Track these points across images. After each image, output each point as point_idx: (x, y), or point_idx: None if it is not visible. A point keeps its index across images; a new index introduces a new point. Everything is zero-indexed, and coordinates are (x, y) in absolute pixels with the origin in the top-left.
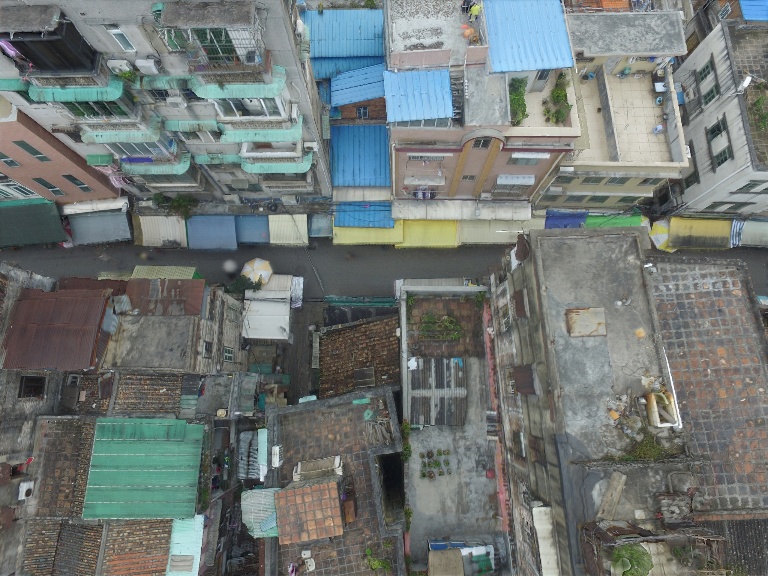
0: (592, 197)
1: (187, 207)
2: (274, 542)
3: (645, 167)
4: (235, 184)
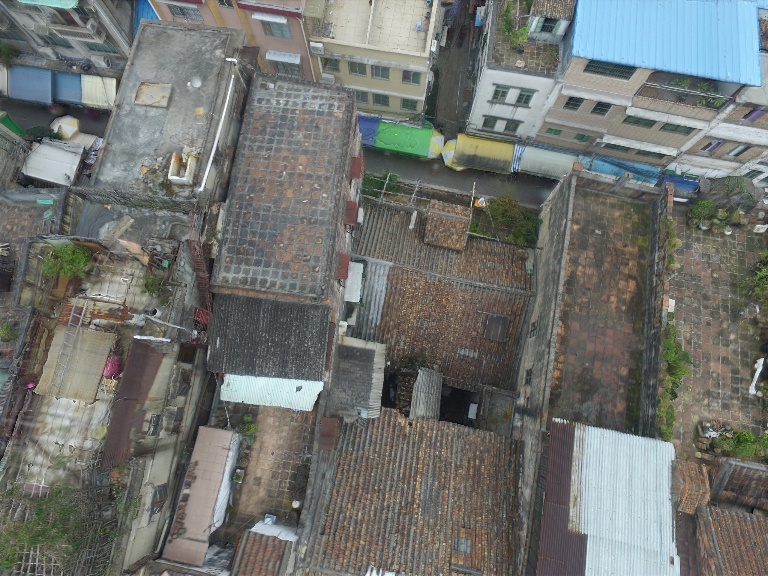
0: (375, 97)
1: (9, 56)
2: None
3: (390, 53)
4: (37, 30)
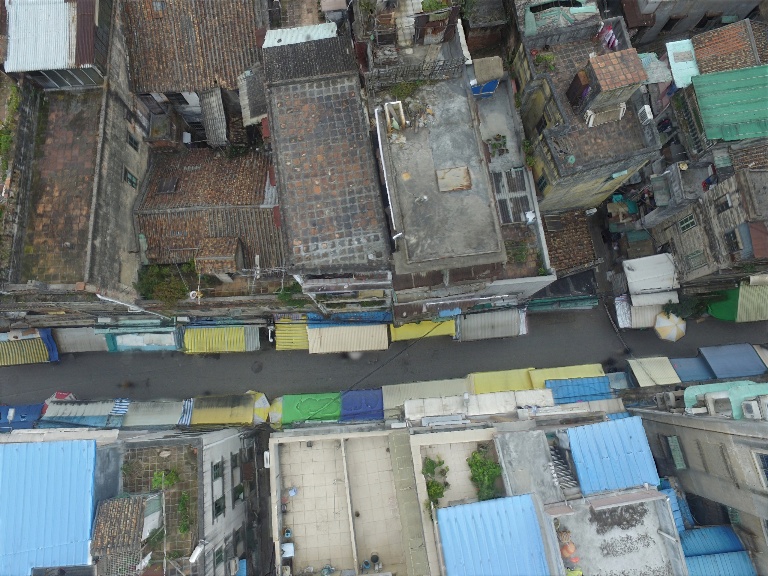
0: None
1: None
2: None
3: None
4: None
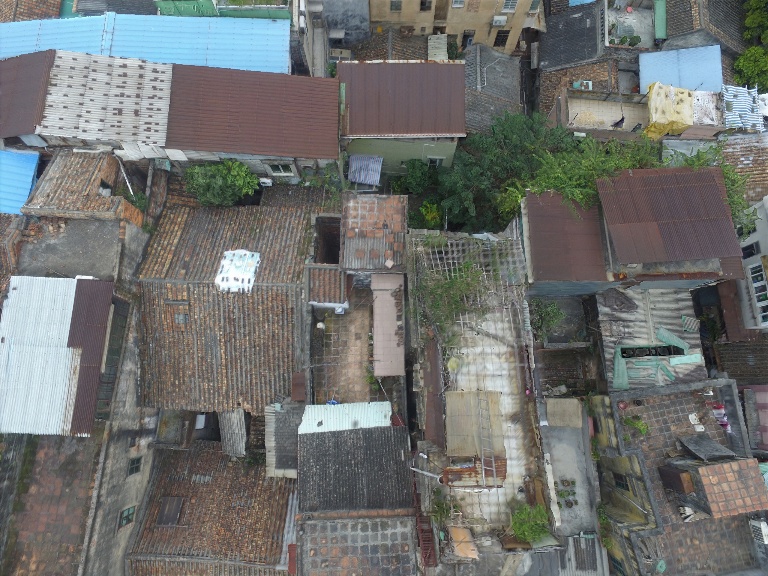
0: None
1: None
2: (735, 441)
3: None
4: None
